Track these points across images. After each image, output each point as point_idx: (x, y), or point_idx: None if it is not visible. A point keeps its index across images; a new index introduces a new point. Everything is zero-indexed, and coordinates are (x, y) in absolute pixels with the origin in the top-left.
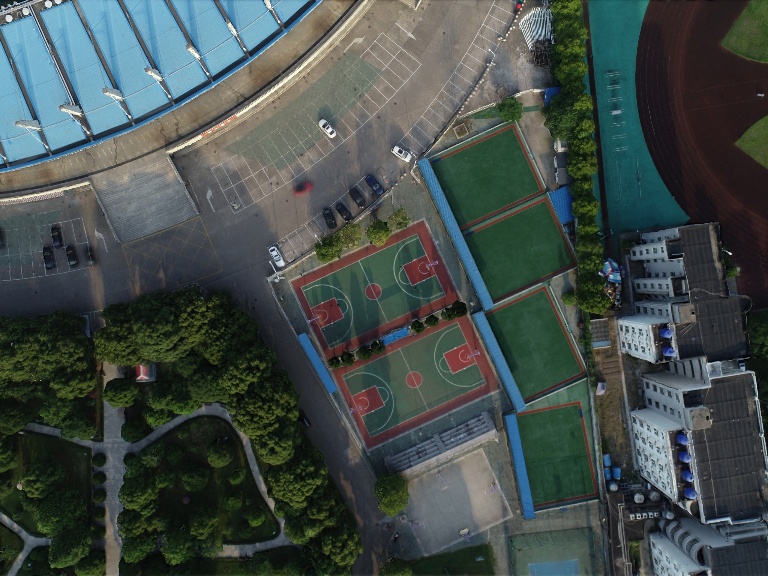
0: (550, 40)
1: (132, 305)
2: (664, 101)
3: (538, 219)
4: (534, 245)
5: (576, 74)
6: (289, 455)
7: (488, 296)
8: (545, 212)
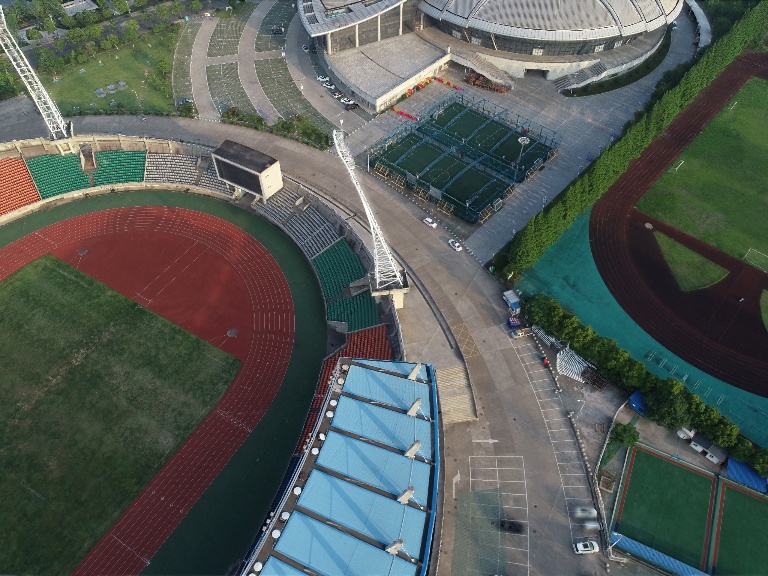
0: (589, 366)
1: None
2: (699, 347)
3: (741, 506)
4: (766, 532)
5: (644, 371)
6: None
7: None
8: (737, 495)
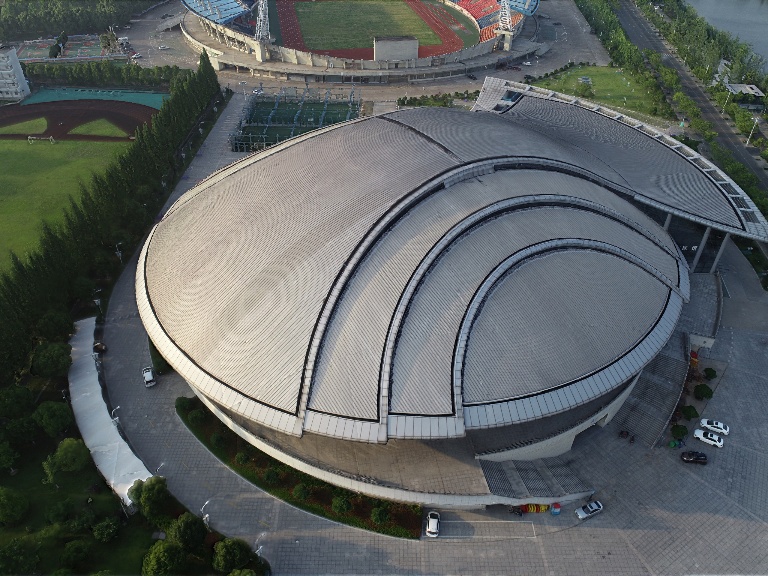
0: None
1: (126, 3)
2: None
3: None
4: None
5: None
6: (38, 15)
7: (50, 60)
8: None
